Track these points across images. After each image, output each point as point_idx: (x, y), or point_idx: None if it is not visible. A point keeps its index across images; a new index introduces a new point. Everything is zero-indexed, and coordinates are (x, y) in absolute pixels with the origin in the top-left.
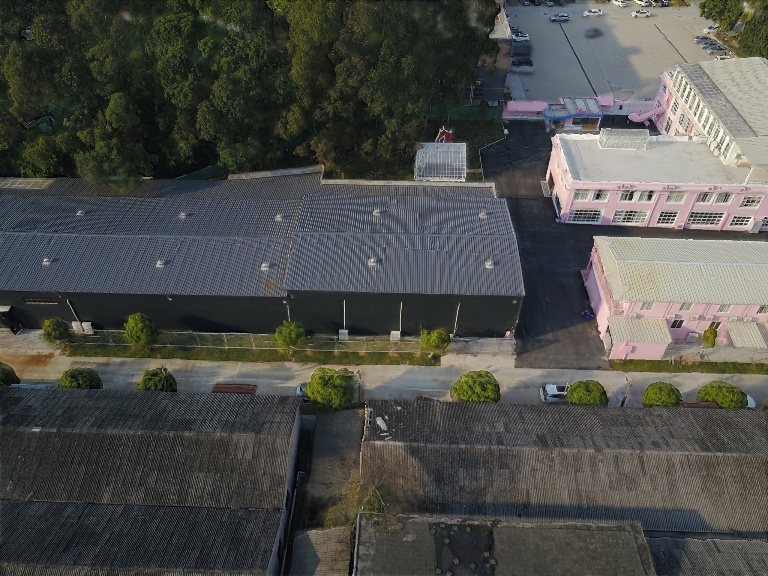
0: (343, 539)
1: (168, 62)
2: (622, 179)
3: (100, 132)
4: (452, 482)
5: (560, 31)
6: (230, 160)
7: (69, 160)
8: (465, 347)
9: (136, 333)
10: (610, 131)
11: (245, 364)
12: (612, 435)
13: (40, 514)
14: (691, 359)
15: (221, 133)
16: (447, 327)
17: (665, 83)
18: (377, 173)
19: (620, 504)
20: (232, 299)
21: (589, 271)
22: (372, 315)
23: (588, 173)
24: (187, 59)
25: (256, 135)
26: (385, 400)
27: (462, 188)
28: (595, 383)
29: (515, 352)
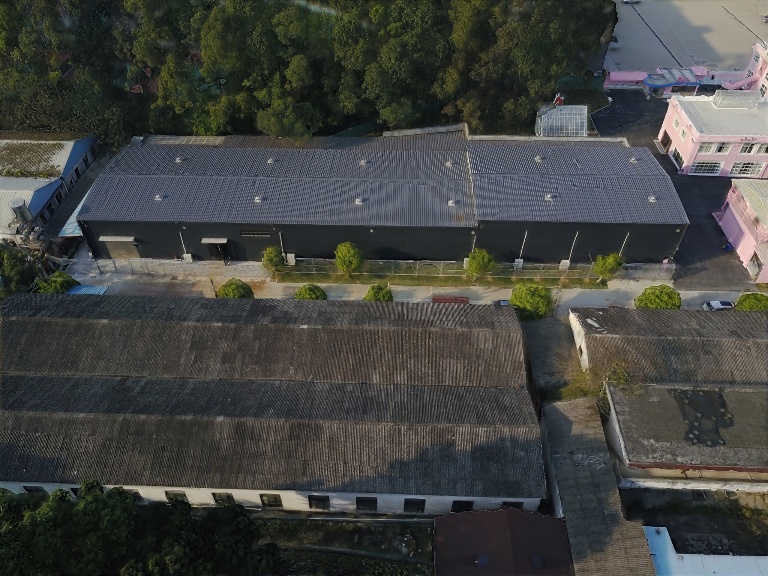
0: (590, 406)
1: (343, 27)
2: (742, 133)
3: (278, 91)
4: (666, 366)
5: (634, 12)
6: (391, 117)
7: (234, 120)
8: (627, 274)
9: (349, 258)
10: (726, 92)
11: (436, 288)
12: None
13: (326, 390)
14: None
15: (385, 92)
16: None
17: (758, 53)
18: (502, 134)
19: None
20: (428, 230)
21: (724, 211)
22: (548, 245)
23: (710, 129)
24: (360, 25)
25: (409, 96)
26: (585, 308)
27: (596, 143)
28: (762, 295)
29: (672, 278)
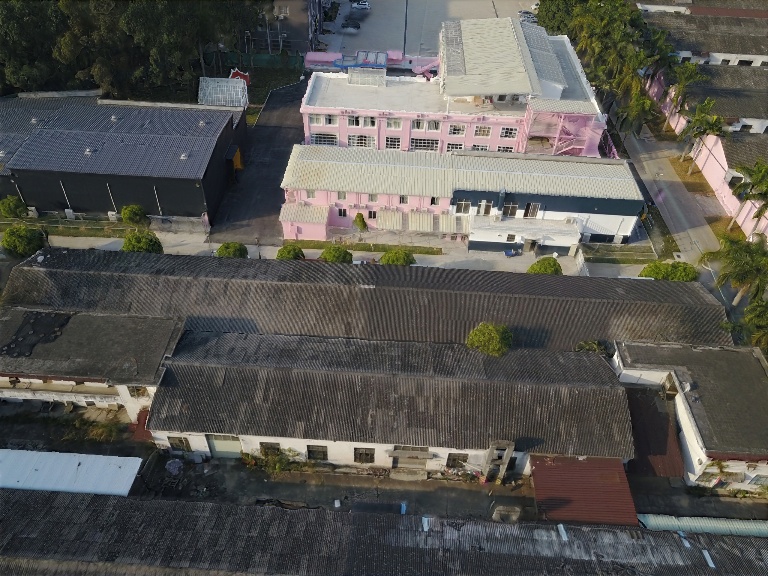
0: None
1: None
2: (350, 107)
3: None
4: (74, 296)
5: (403, 3)
6: (12, 77)
7: None
8: (169, 227)
9: None
10: (353, 69)
11: None
12: (217, 271)
13: None
14: (350, 240)
15: (3, 53)
16: (153, 209)
17: (440, 39)
18: None
19: (198, 314)
20: None
21: None
22: (88, 196)
23: (324, 102)
24: None
25: (42, 59)
26: (59, 248)
27: (217, 111)
28: (236, 243)
29: (209, 231)
